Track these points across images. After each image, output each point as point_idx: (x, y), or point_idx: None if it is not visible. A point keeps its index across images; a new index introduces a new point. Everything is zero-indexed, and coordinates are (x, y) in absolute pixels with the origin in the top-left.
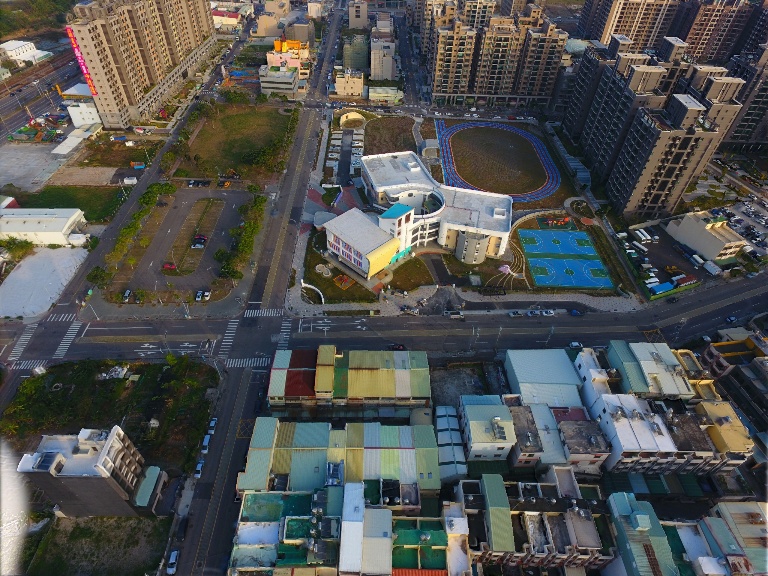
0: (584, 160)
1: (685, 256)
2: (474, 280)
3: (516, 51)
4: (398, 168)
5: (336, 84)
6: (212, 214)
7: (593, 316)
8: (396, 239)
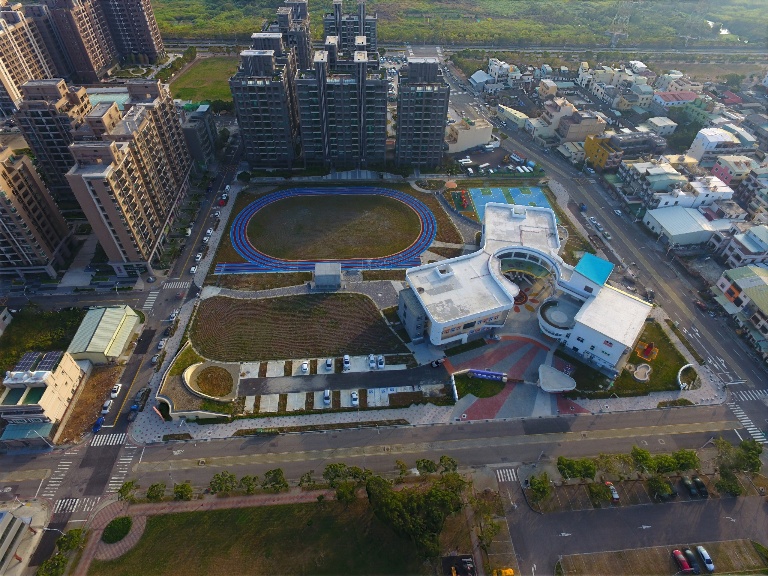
0: (339, 169)
1: (483, 152)
2: (581, 255)
3: (157, 135)
4: (451, 286)
5: (46, 412)
6: (608, 570)
7: (579, 201)
8: (606, 284)
